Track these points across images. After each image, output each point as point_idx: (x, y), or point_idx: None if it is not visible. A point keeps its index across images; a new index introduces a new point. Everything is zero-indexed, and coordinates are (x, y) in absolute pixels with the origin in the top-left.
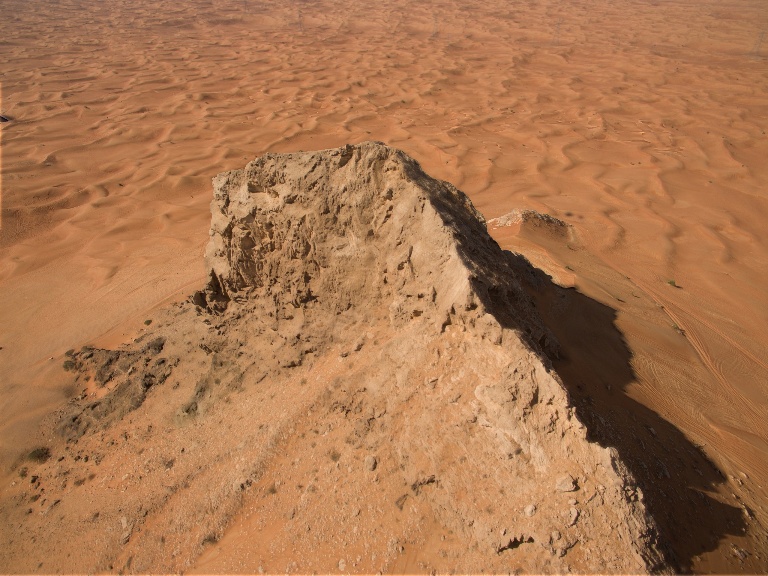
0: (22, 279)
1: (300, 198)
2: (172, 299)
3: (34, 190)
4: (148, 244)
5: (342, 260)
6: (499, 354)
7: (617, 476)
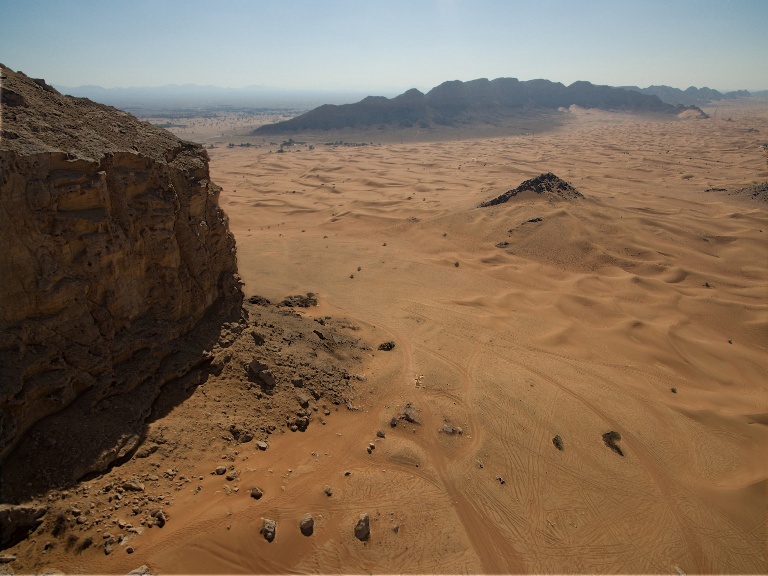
0: (476, 275)
1: None
2: (369, 327)
3: (638, 245)
4: (550, 320)
5: None
6: None
7: None
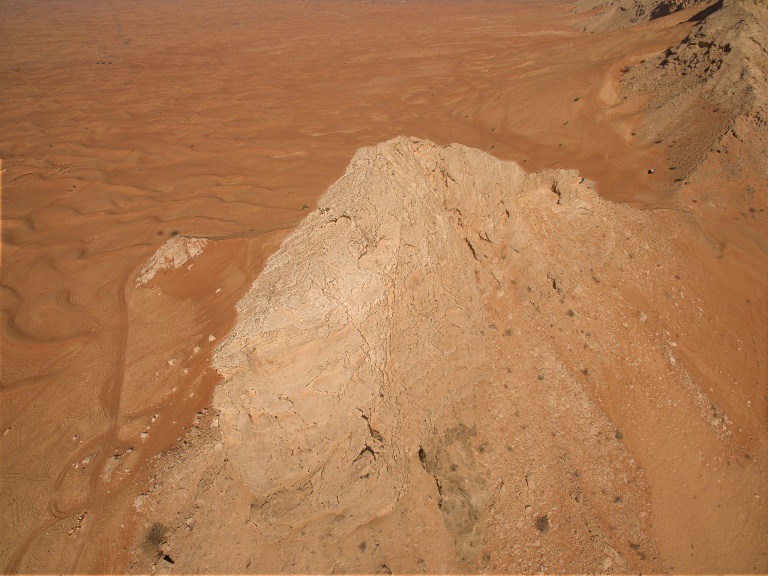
0: None
1: None
2: None
3: None
4: None
5: None
6: (541, 190)
7: None
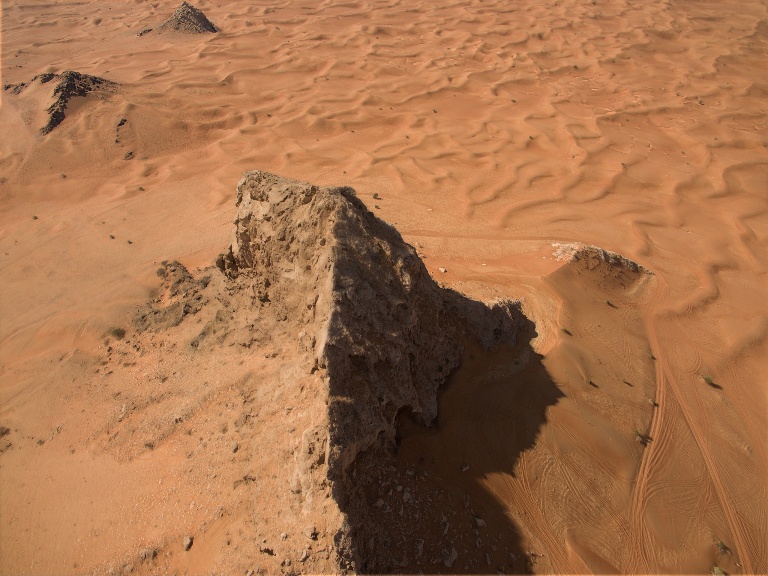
0: (169, 186)
1: (272, 220)
2: None
3: (205, 107)
4: None
5: (287, 281)
6: None
7: (335, 546)
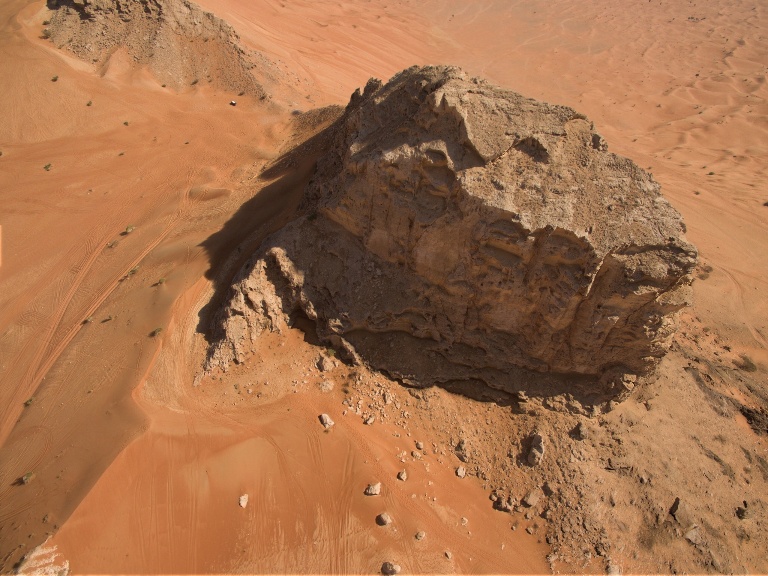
0: None
1: None
2: None
3: None
4: None
5: None
6: None
7: None
